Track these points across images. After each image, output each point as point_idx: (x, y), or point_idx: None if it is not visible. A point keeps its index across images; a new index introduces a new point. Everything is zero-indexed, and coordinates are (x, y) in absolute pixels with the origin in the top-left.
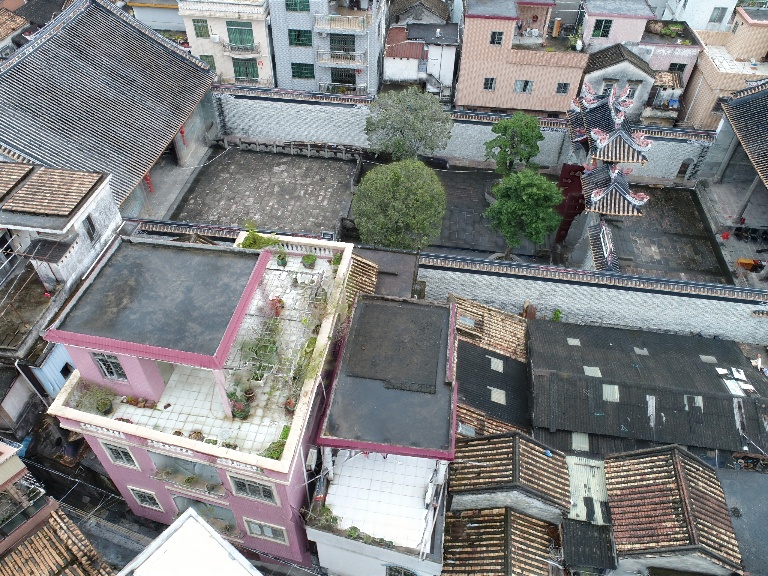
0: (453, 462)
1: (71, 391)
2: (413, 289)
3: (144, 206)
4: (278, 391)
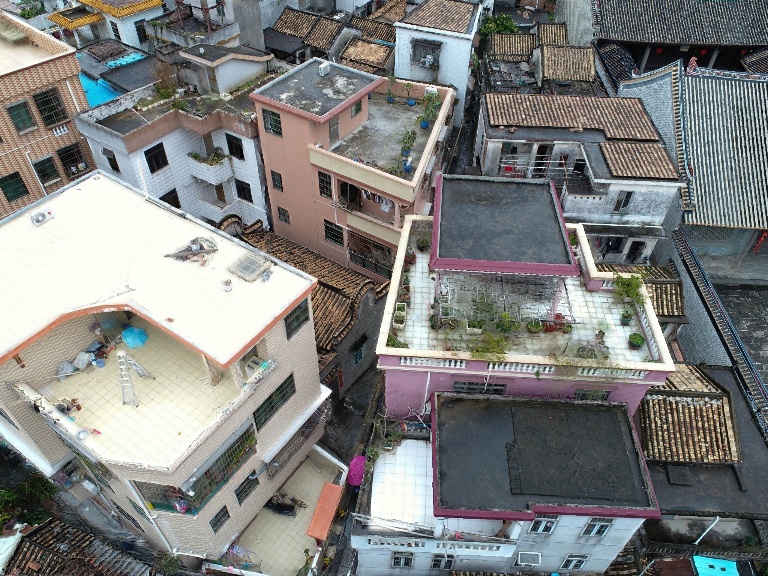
0: (485, 574)
1: (425, 220)
2: (726, 512)
3: (736, 256)
4: (465, 345)
